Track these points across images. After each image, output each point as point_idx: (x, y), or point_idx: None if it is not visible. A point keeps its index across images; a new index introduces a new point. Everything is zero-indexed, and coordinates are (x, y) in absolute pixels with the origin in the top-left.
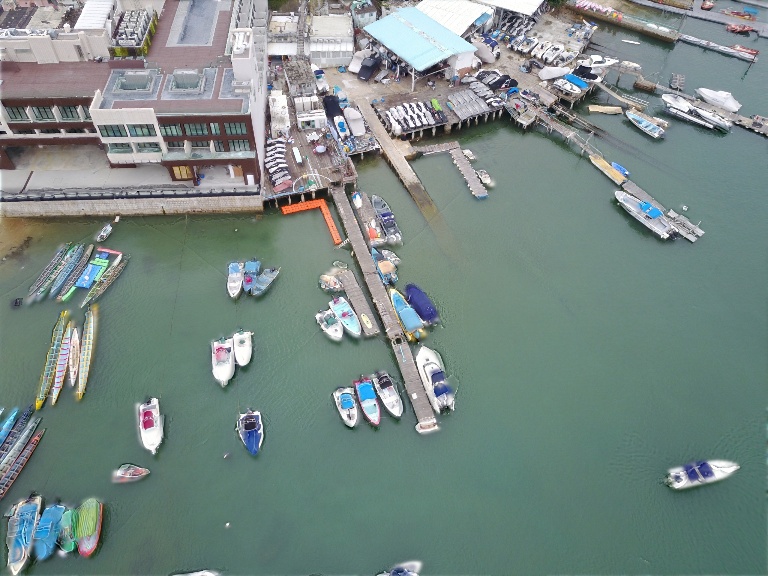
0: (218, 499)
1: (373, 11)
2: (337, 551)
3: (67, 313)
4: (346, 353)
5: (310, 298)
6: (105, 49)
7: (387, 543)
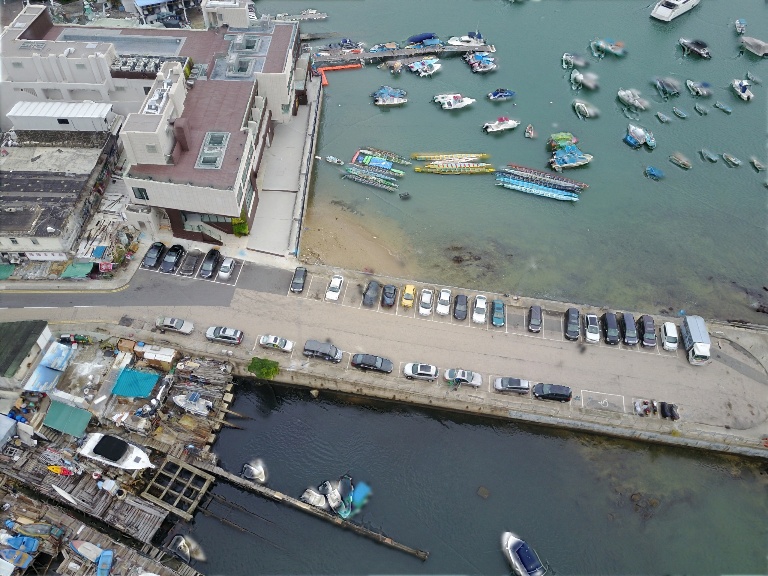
0: (537, 110)
1: (102, 4)
2: (551, 86)
3: (418, 167)
4: (449, 67)
5: (405, 79)
6: (183, 75)
7: (545, 72)
